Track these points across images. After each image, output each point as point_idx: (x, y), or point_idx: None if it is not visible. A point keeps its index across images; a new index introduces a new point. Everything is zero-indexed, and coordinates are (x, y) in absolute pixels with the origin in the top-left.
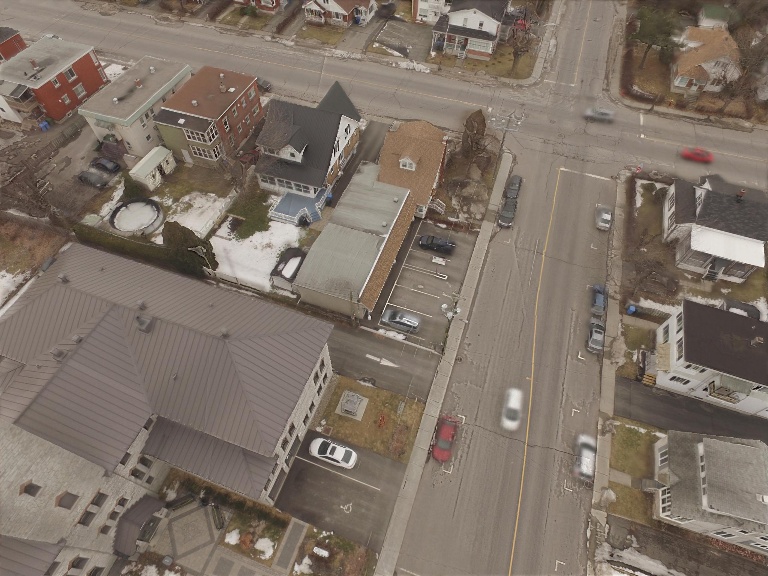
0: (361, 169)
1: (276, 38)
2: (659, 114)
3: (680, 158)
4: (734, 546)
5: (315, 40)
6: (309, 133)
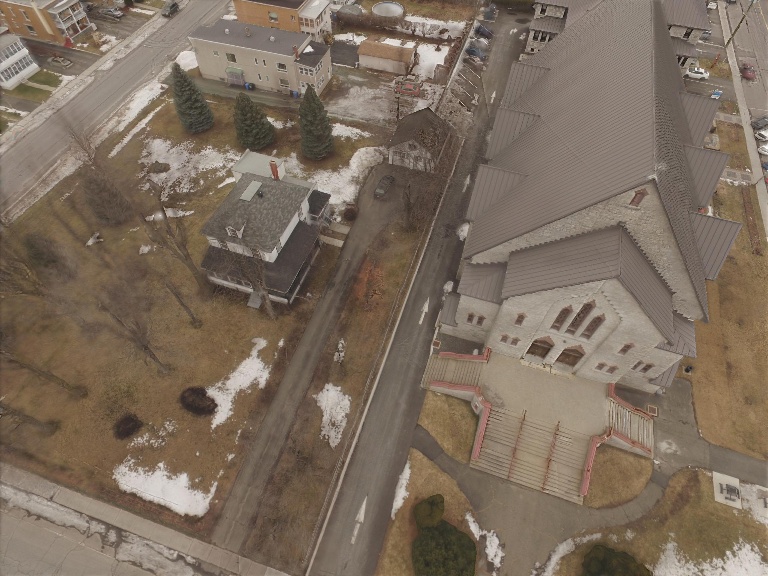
0: None
1: None
2: None
3: None
4: None
5: None
6: None
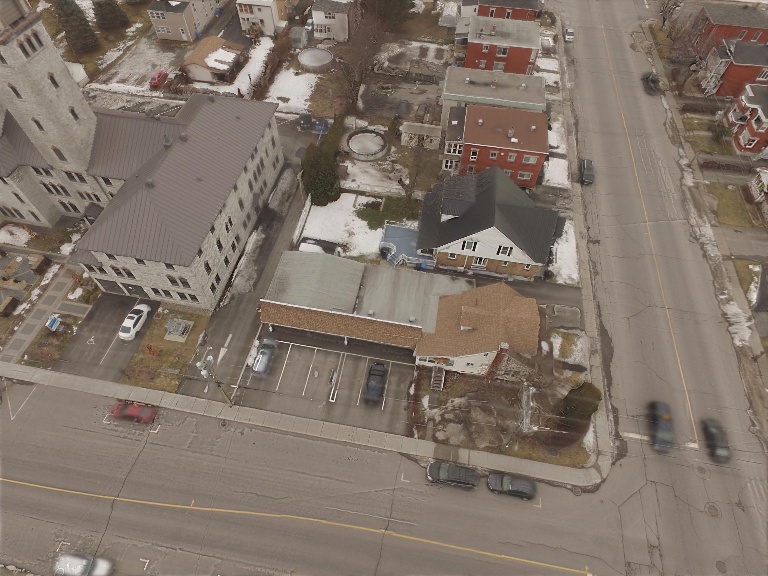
0: (459, 280)
1: (690, 168)
2: None
3: None
4: None
5: (714, 202)
6: (470, 212)
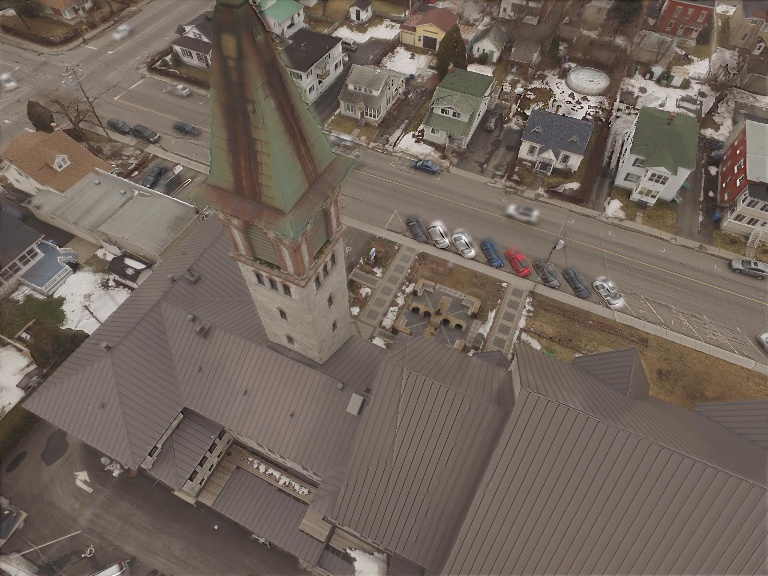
0: (36, 205)
1: None
2: (92, 39)
3: (145, 44)
4: (393, 106)
5: None
6: None
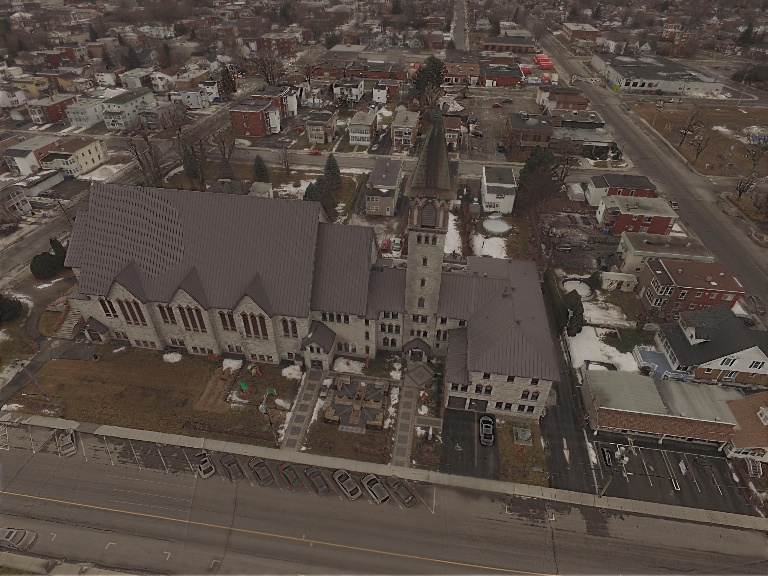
0: (729, 389)
1: None
2: None
3: None
4: None
5: None
6: (720, 336)
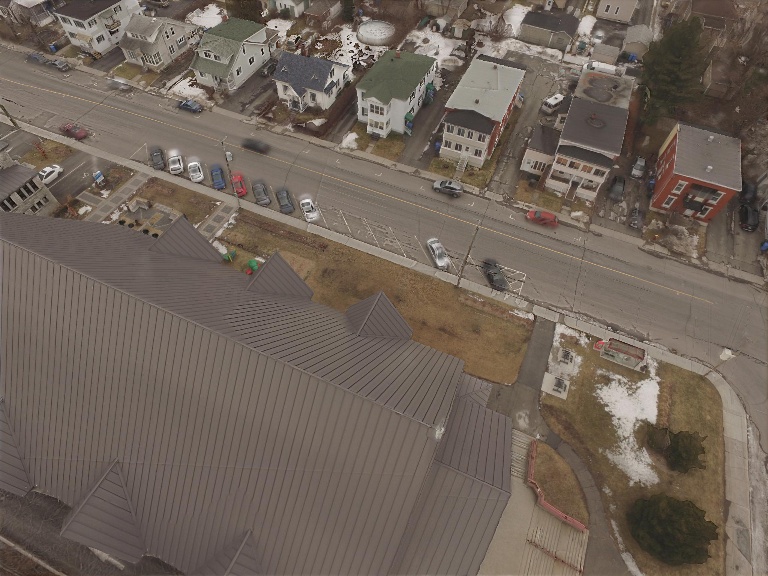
0: None
1: None
2: None
3: None
4: (182, 55)
5: None
6: None
